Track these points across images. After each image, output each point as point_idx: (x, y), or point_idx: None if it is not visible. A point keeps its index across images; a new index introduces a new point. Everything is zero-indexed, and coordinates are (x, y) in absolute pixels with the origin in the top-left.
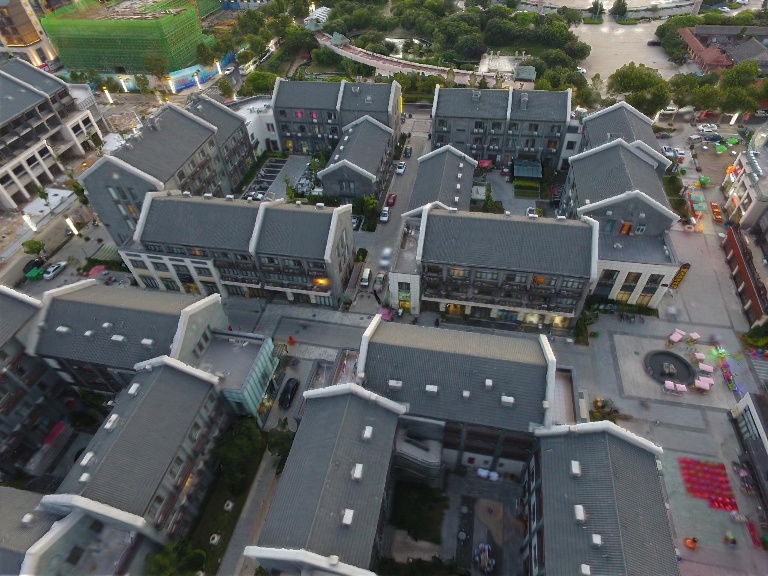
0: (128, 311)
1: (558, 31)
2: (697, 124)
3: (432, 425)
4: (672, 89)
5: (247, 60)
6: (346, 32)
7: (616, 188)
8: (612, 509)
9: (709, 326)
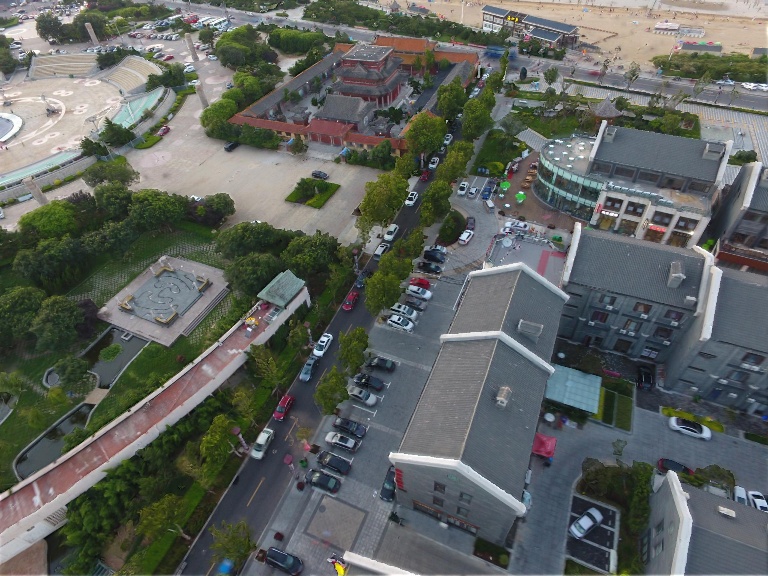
0: None
1: (164, 204)
2: None
3: None
4: None
5: None
6: None
7: None
8: None
9: None
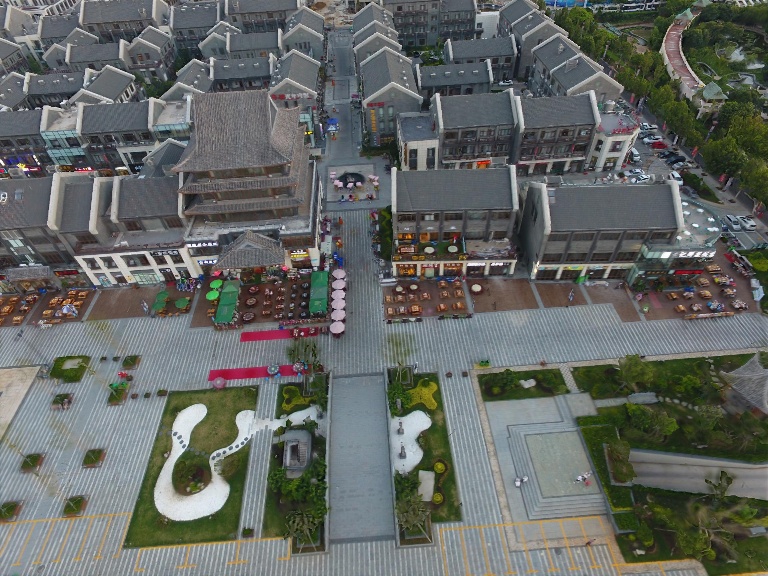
0: None
1: None
2: (755, 219)
3: None
4: None
5: (597, 1)
6: (727, 20)
7: None
8: None
9: None
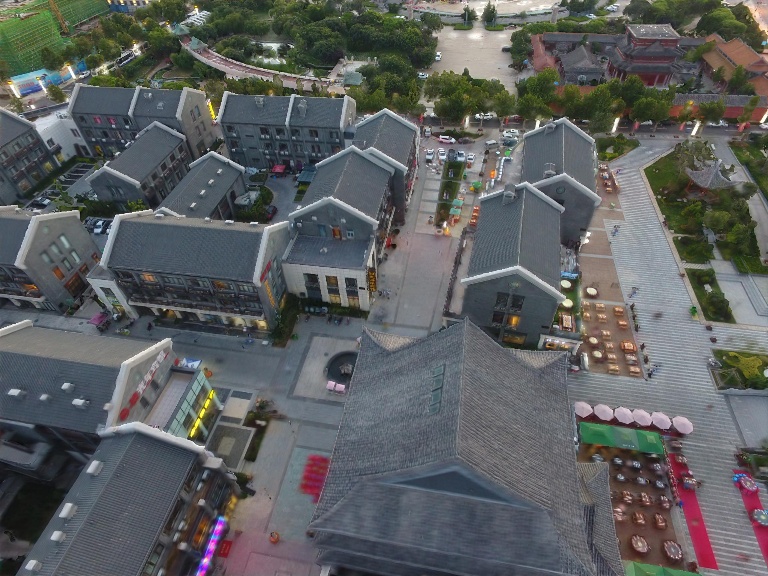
0: None
1: (408, 37)
2: (505, 129)
3: (26, 428)
4: None
5: (96, 64)
6: (215, 36)
7: (324, 194)
8: (90, 507)
9: (408, 327)
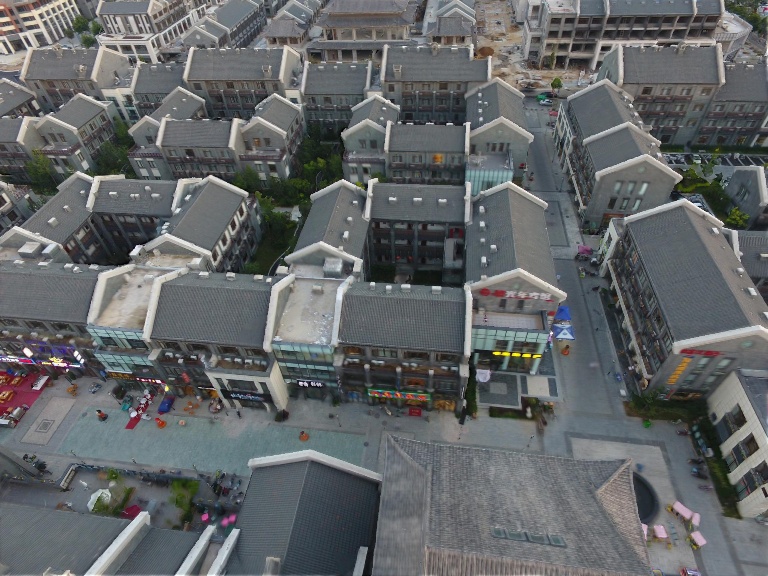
0: (497, 105)
1: None
2: None
3: None
4: None
5: None
6: None
7: None
8: None
9: None
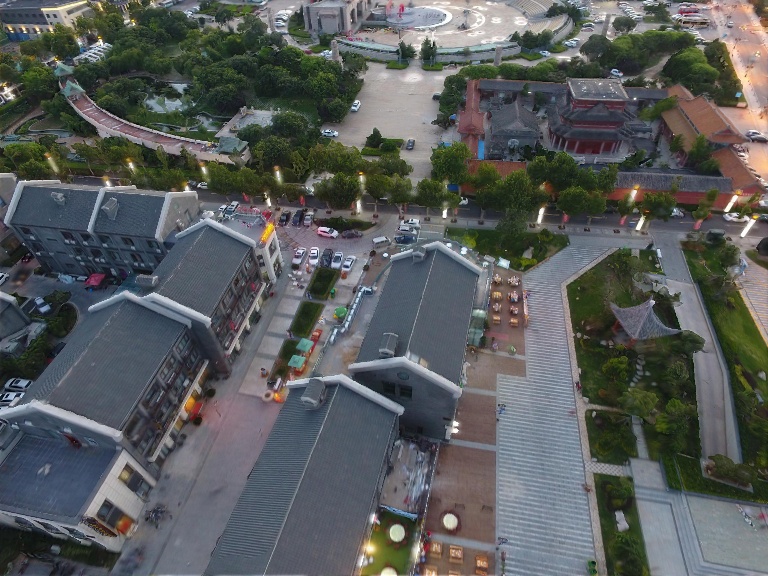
0: None
1: (316, 85)
2: (406, 216)
3: None
4: (385, 171)
5: None
6: (107, 76)
7: None
8: None
9: None
